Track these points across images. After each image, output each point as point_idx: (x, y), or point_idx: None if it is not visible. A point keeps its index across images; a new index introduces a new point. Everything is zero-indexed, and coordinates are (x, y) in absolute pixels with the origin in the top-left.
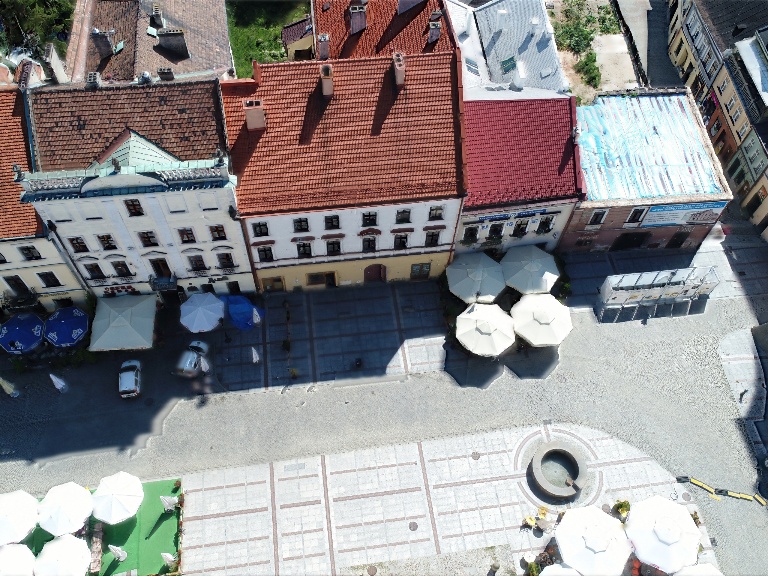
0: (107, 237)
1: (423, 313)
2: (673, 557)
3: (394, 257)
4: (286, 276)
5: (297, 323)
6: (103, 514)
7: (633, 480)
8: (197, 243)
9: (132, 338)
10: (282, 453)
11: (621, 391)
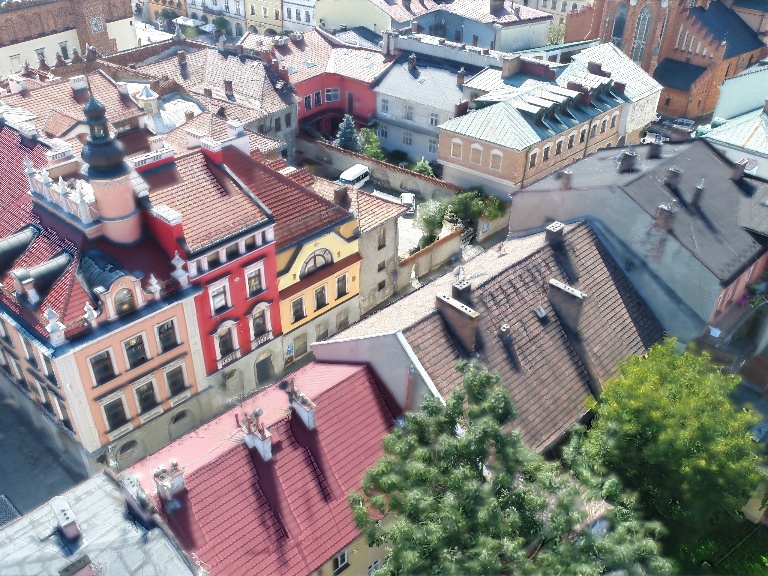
0: None
1: None
2: (136, 32)
3: None
4: None
5: None
6: None
7: None
8: None
9: None
10: None
11: None
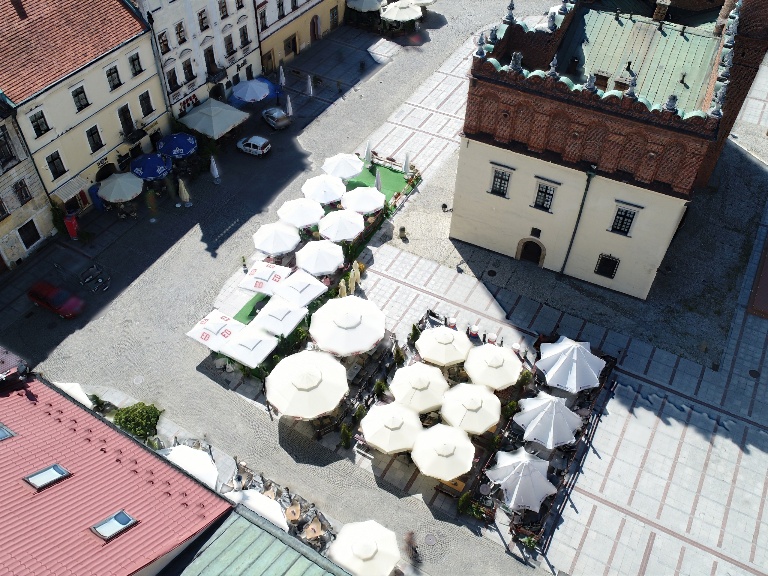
0: (179, 28)
1: (358, 38)
2: None
3: (322, 4)
4: (274, 48)
5: (303, 77)
6: (349, 173)
7: (532, 25)
8: (229, 17)
9: (233, 116)
10: (385, 115)
11: (482, 8)
